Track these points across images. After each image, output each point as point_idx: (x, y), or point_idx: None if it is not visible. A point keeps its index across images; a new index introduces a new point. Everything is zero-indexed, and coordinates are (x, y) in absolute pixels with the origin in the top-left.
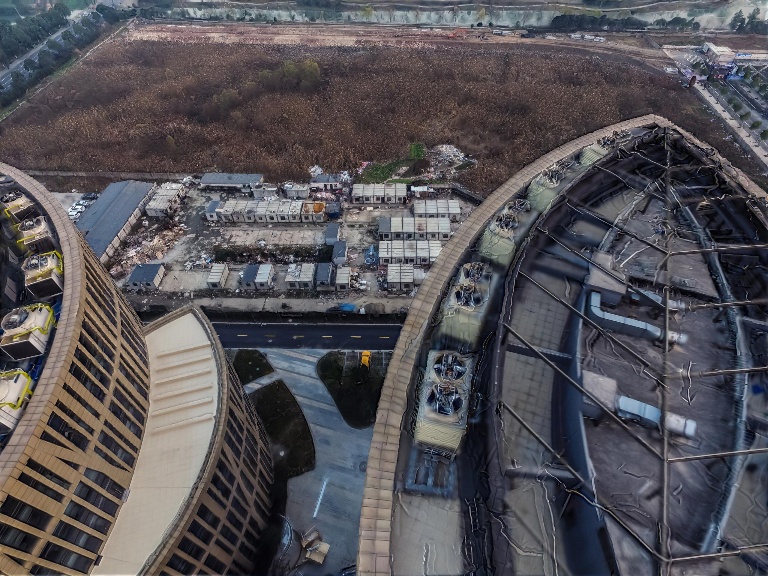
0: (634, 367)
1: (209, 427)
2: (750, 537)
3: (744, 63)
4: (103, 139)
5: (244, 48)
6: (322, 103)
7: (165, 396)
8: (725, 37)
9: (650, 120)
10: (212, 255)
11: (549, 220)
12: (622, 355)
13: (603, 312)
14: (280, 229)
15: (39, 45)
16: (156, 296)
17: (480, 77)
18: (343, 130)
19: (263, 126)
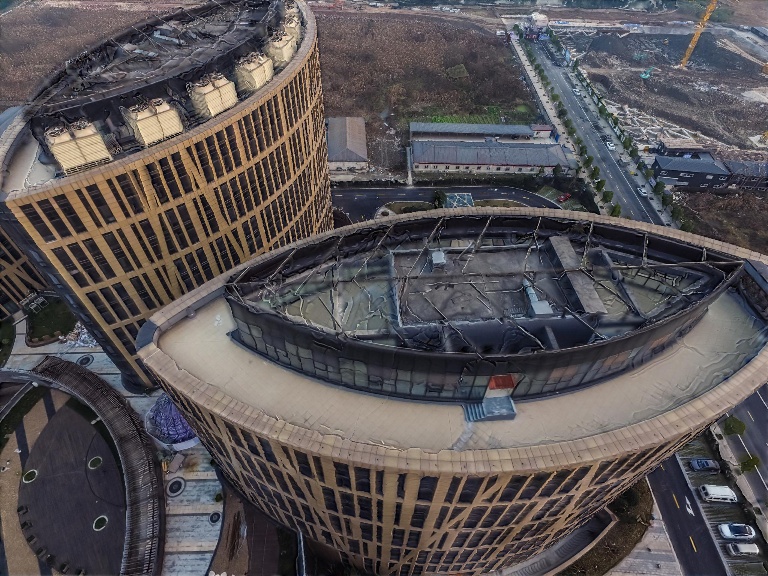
0: None
1: None
2: None
3: (563, 29)
4: (6, 79)
5: (145, 13)
6: None
7: None
8: (557, 10)
9: None
10: None
11: None
12: None
13: None
14: None
15: None
16: None
17: (343, 36)
18: None
19: None
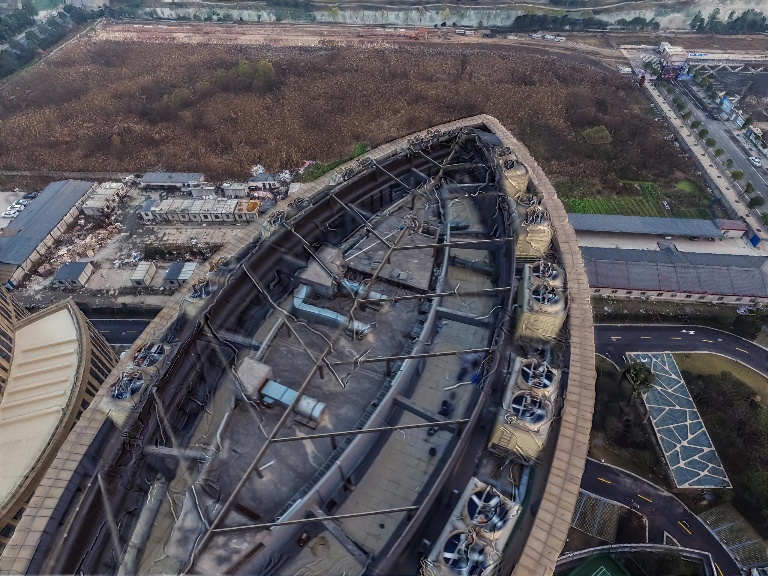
0: (312, 354)
1: (55, 419)
2: (327, 509)
3: (700, 63)
4: (52, 139)
5: (205, 48)
6: (274, 103)
7: (19, 389)
8: (685, 37)
9: (479, 120)
10: (142, 253)
11: (308, 216)
12: (310, 343)
13: (301, 303)
14: (214, 227)
15: (4, 45)
16: (81, 294)
17: (434, 77)
18: (289, 129)
19: (211, 126)
